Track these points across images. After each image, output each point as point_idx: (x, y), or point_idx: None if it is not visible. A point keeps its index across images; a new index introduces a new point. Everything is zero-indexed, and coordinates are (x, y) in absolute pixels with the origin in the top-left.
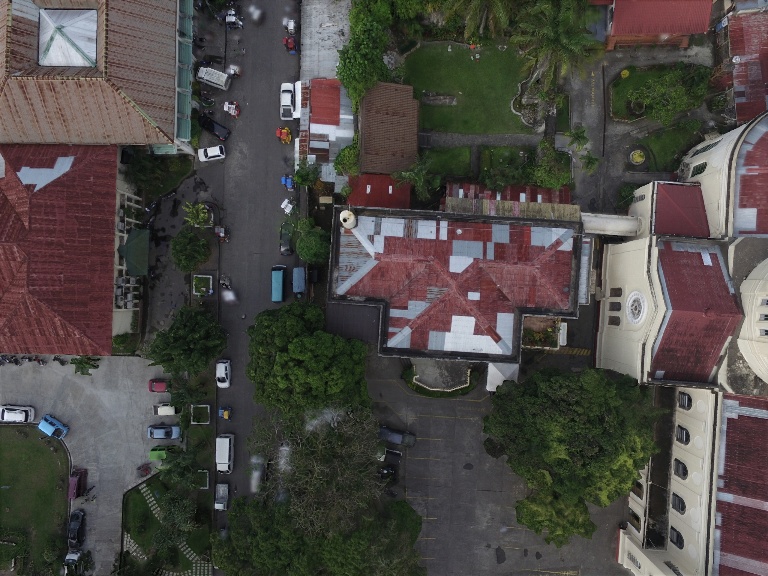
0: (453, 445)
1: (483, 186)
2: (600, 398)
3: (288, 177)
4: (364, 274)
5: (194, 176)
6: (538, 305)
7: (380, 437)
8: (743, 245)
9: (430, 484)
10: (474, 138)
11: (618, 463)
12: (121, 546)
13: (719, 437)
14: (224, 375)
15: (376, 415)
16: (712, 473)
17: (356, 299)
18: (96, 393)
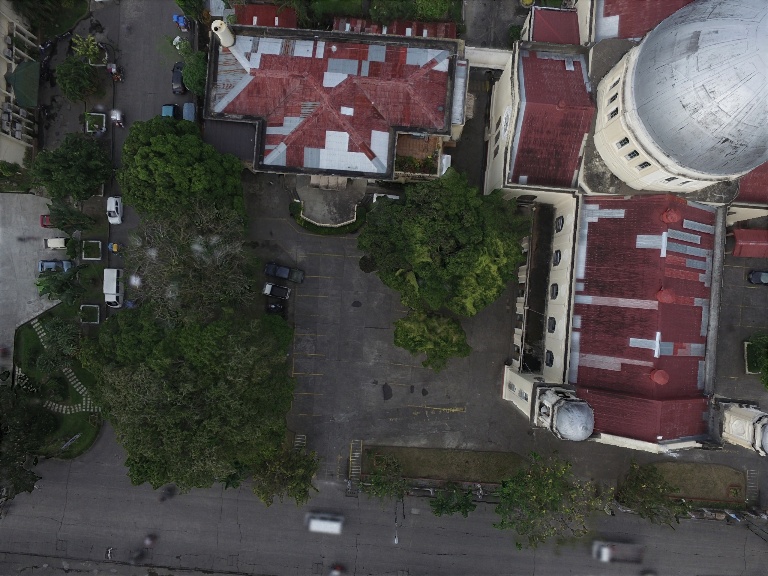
0: (342, 283)
1: (370, 21)
2: (460, 197)
3: (181, 16)
4: (240, 90)
5: (90, 18)
6: (413, 124)
7: (268, 272)
8: (601, 46)
9: (319, 321)
10: None
11: (480, 266)
12: (12, 380)
13: (578, 238)
14: (114, 209)
15: (266, 253)
16: (572, 275)
17: (233, 117)
18: None
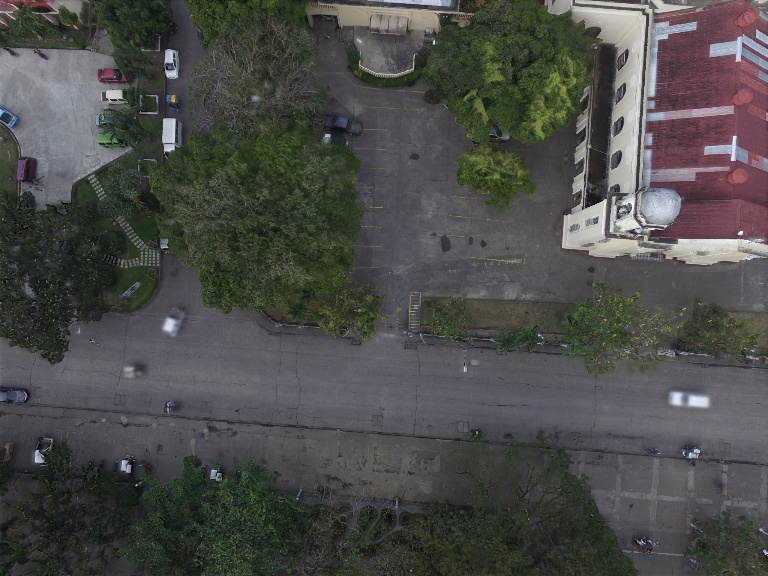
0: (399, 135)
1: None
2: (531, 12)
3: None
4: None
5: None
6: None
7: (326, 124)
8: None
9: (376, 174)
10: None
11: (550, 85)
12: None
13: (649, 53)
14: (172, 61)
15: (323, 107)
16: (643, 92)
17: None
18: (46, 85)
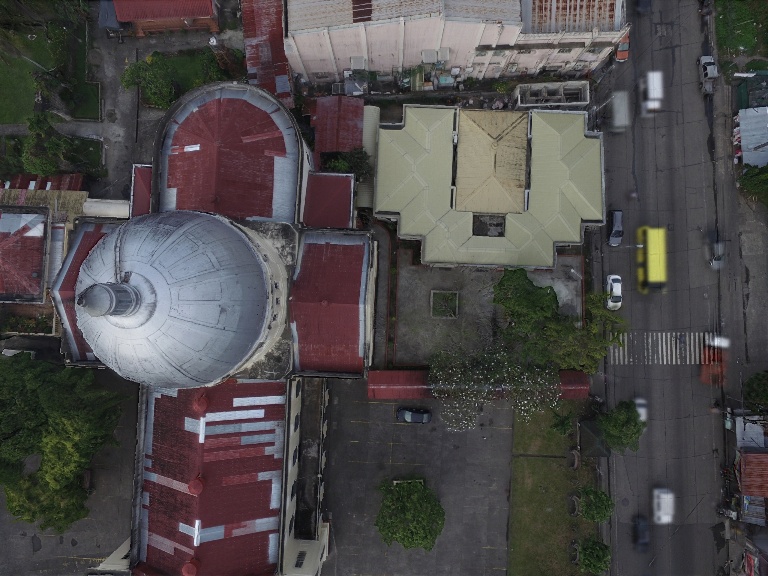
0: None
1: None
2: (14, 381)
3: None
4: None
5: None
6: (8, 291)
7: None
8: None
9: None
10: (4, 128)
11: (48, 446)
12: None
13: None
14: None
15: None
16: None
17: None
18: None
